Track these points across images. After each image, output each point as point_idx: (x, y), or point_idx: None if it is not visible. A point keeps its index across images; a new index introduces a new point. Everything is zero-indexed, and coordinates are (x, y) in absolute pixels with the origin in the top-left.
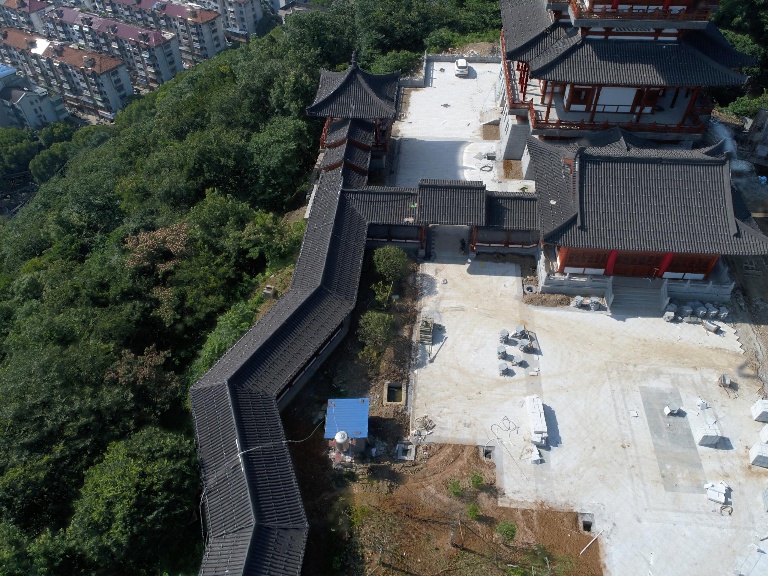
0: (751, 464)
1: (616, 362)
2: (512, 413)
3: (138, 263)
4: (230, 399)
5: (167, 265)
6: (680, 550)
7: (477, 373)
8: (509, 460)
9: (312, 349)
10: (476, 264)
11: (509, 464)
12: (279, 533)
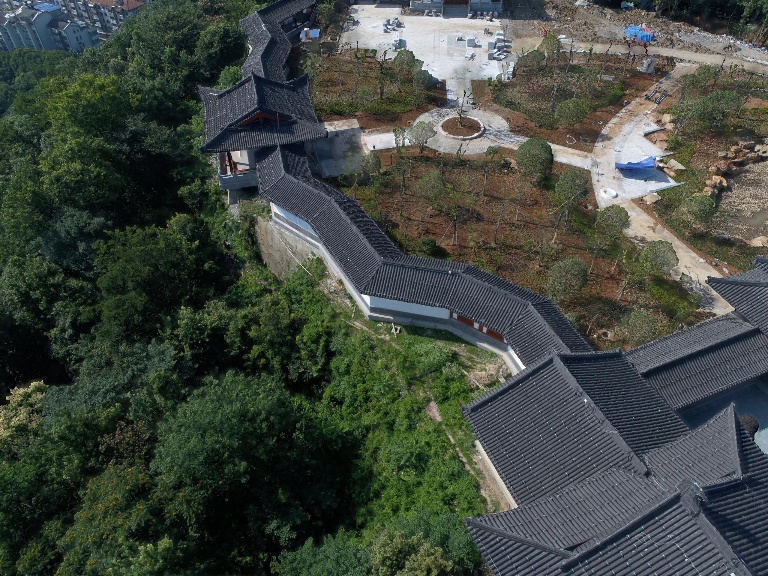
0: (488, 50)
1: (439, 29)
2: (386, 41)
3: (205, 4)
4: (258, 15)
5: (220, 4)
6: (448, 67)
7: (373, 33)
8: (382, 51)
9: (294, 12)
10: (380, 5)
11: (382, 52)
12: (281, 44)
